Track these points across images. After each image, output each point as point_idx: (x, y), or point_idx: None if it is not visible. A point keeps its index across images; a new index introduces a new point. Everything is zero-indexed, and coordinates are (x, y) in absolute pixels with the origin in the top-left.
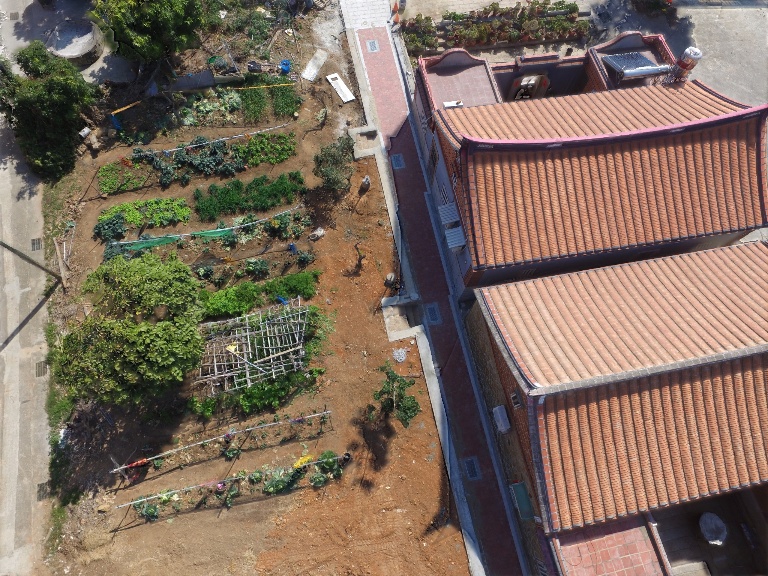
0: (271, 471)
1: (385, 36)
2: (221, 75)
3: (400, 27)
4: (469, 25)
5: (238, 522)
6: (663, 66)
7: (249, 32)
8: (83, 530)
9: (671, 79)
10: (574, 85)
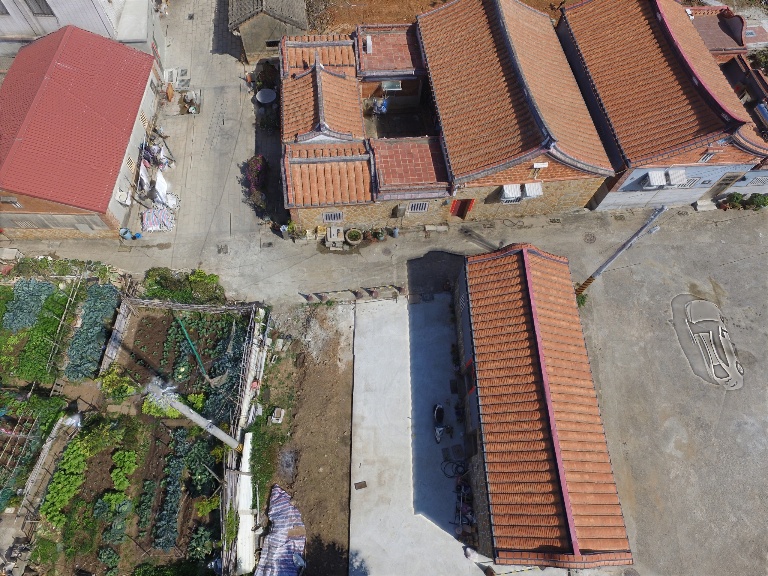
0: None
1: (763, 40)
2: None
3: None
4: None
5: None
6: None
7: None
8: None
9: (767, 136)
10: None
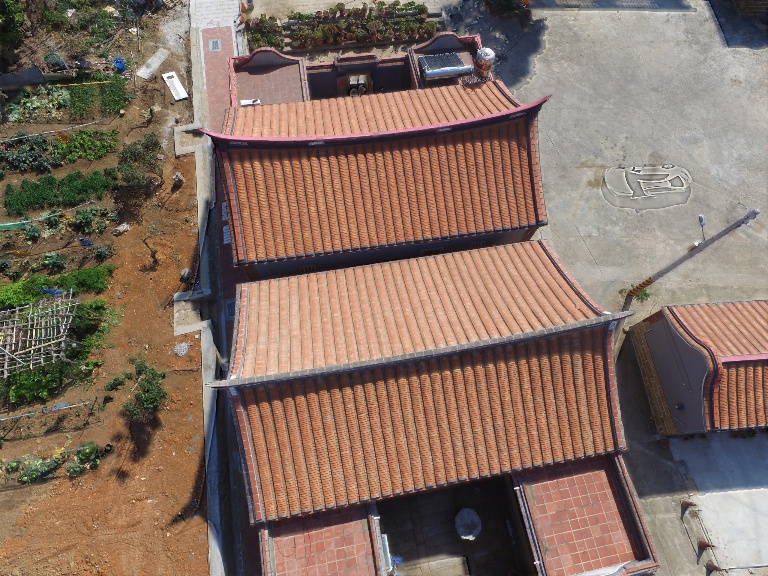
0: (15, 460)
1: (229, 35)
2: (51, 72)
3: (245, 27)
4: (314, 25)
5: None
6: (467, 66)
7: (92, 30)
8: None
9: (473, 79)
10: (406, 85)
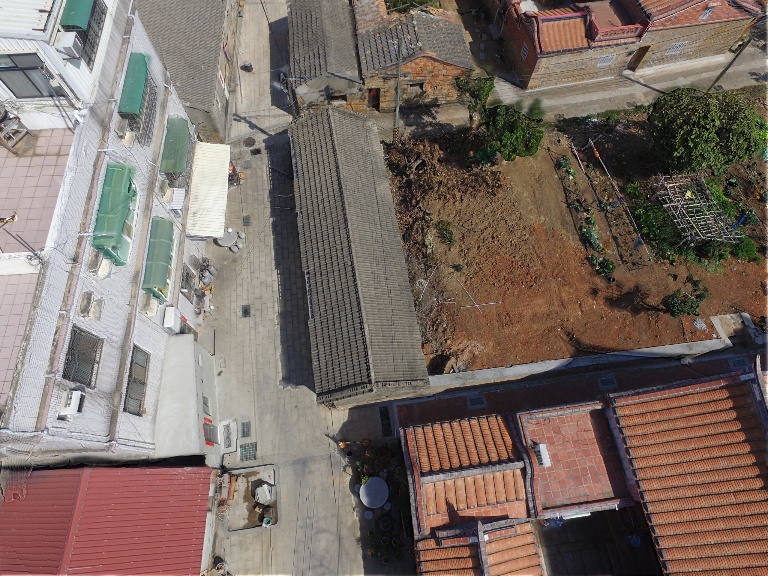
0: None
1: None
2: None
3: None
4: None
5: (560, 213)
6: None
7: None
8: (546, 135)
9: None
10: None
